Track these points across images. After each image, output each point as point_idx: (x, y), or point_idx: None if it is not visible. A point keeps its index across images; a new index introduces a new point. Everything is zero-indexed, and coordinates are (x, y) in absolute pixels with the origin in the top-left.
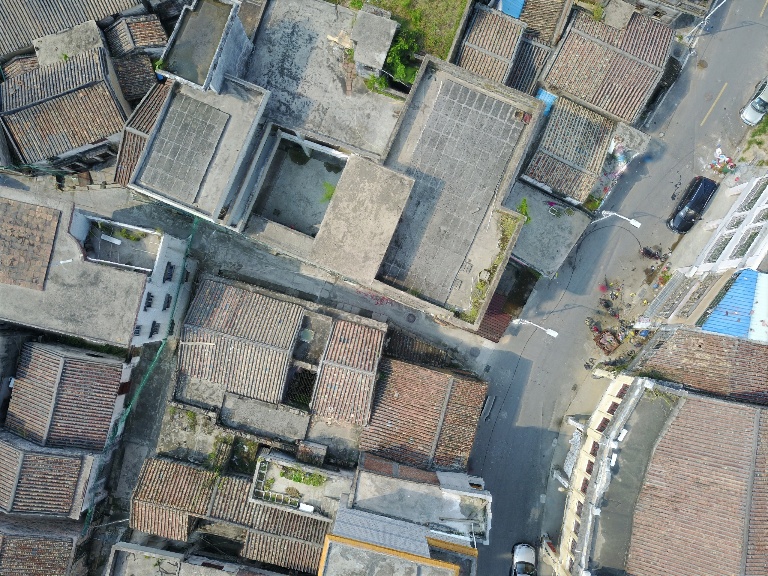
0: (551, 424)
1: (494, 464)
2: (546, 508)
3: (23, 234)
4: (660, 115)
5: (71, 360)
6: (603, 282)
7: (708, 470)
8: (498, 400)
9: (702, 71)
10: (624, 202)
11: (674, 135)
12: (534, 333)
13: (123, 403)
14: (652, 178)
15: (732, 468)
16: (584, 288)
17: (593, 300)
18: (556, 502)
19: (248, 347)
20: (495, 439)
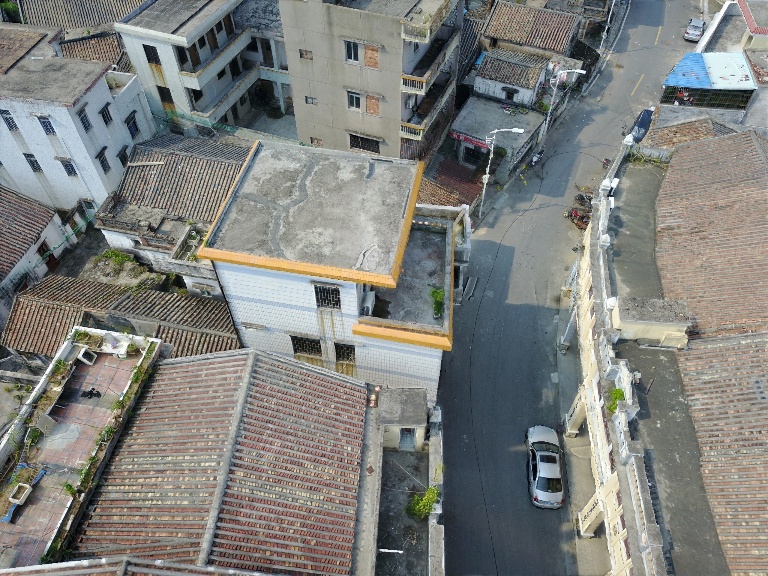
0: (548, 302)
1: (485, 341)
2: (561, 387)
3: (5, 43)
4: (593, 91)
5: (3, 188)
6: (574, 188)
7: (724, 192)
8: (481, 281)
9: (620, 69)
10: (578, 137)
11: (610, 100)
12: (511, 226)
13: (42, 277)
14: (599, 123)
15: (749, 182)
16: (556, 192)
17: (568, 200)
18: (573, 380)
19: (199, 163)
20: (483, 317)
